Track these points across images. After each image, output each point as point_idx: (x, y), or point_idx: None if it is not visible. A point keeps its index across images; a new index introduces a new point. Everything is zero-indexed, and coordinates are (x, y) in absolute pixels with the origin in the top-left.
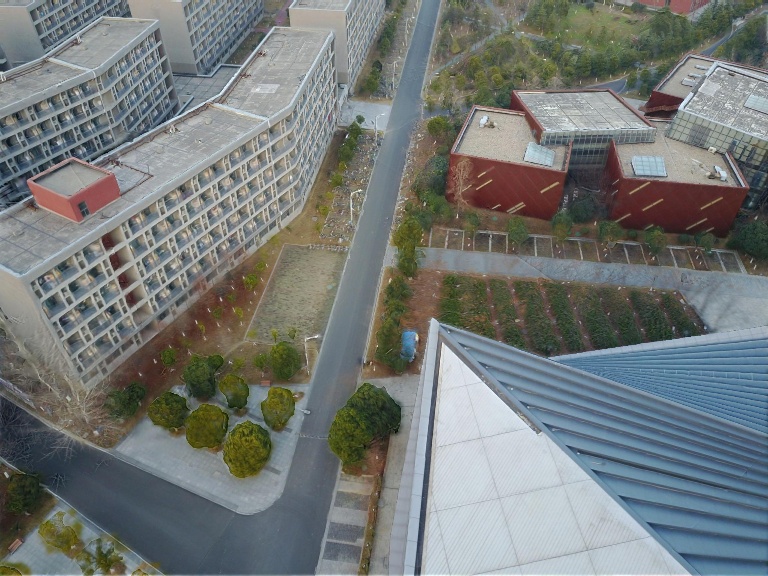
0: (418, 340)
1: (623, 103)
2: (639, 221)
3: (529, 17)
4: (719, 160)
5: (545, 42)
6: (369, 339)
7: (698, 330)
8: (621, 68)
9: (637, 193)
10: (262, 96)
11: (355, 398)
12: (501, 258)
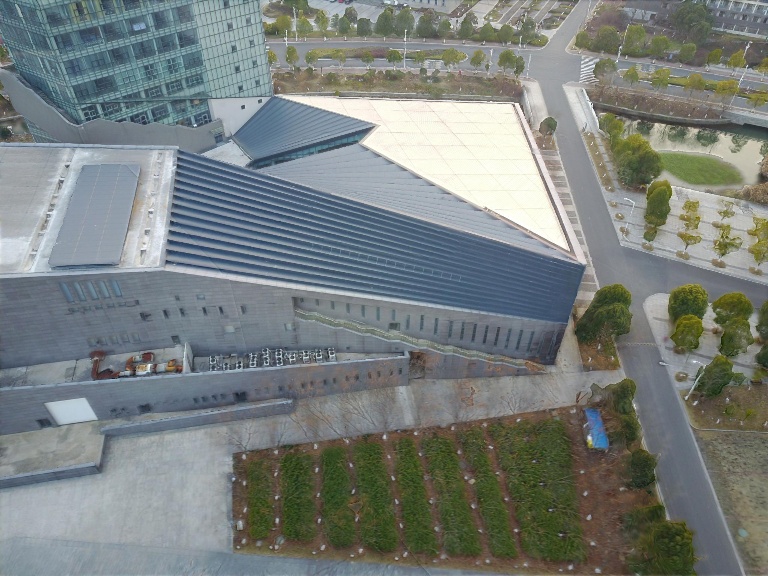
0: None
1: None
2: None
3: None
4: None
5: None
6: (645, 446)
7: (244, 476)
8: None
9: None
10: None
11: None
12: None
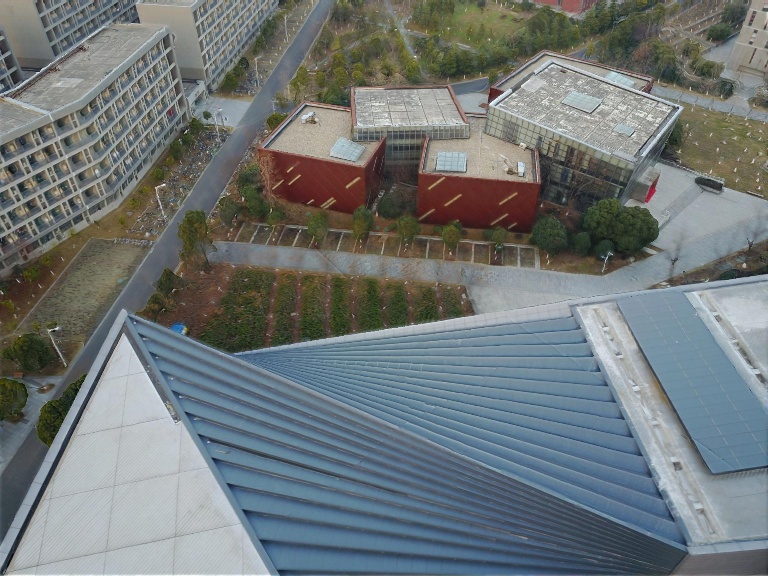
0: (186, 333)
1: (453, 99)
2: (444, 216)
3: (415, 15)
4: (527, 156)
5: (422, 39)
6: None
7: None
8: (492, 65)
9: (435, 188)
10: (59, 90)
11: (67, 389)
12: (301, 253)
